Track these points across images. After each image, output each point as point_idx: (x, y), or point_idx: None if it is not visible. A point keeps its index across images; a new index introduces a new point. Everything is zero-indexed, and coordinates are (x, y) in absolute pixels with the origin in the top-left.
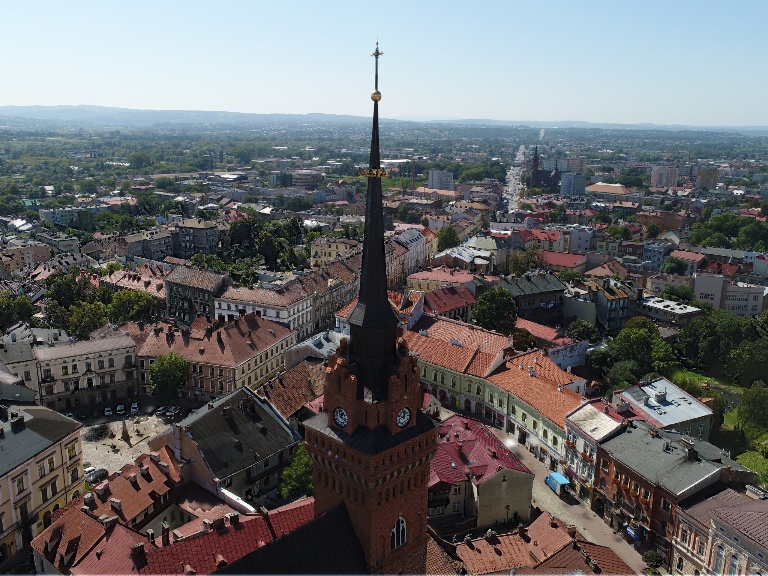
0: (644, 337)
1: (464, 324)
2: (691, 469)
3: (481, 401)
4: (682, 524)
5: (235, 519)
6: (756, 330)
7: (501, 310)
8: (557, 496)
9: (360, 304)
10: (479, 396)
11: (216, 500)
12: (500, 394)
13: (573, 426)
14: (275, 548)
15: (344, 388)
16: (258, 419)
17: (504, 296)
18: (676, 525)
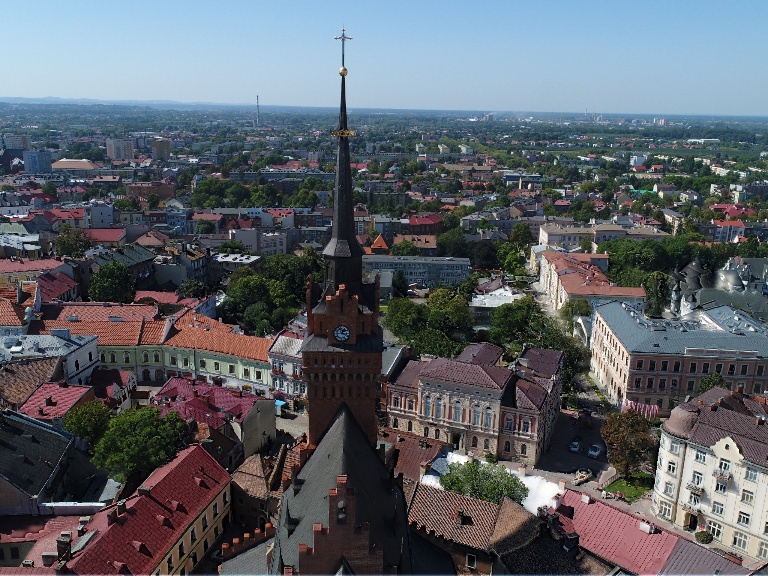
0: (260, 282)
1: (98, 304)
2: (384, 356)
3: (161, 367)
4: (394, 394)
5: (123, 507)
6: (317, 263)
7: (124, 284)
8: (278, 417)
9: (341, 241)
10: (158, 363)
11: (41, 518)
12: (184, 354)
13: (279, 355)
14: (347, 443)
15: (348, 308)
16: (19, 431)
17: (122, 270)
18: (389, 397)
